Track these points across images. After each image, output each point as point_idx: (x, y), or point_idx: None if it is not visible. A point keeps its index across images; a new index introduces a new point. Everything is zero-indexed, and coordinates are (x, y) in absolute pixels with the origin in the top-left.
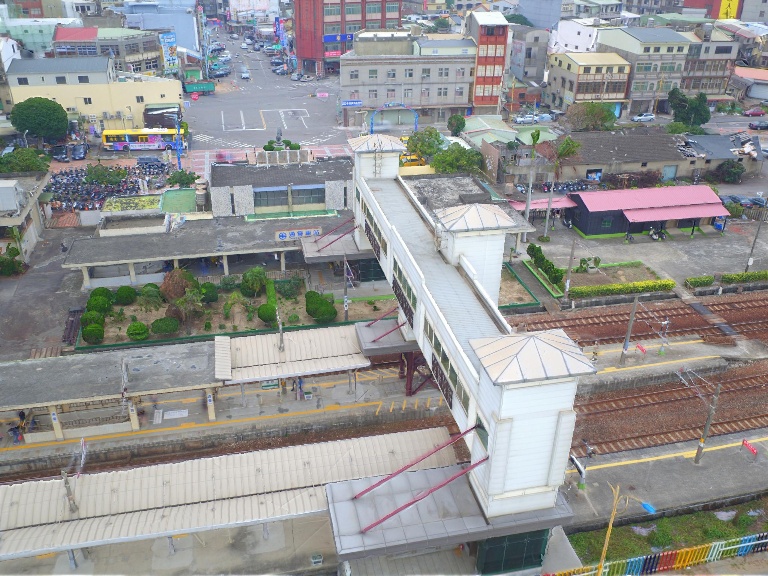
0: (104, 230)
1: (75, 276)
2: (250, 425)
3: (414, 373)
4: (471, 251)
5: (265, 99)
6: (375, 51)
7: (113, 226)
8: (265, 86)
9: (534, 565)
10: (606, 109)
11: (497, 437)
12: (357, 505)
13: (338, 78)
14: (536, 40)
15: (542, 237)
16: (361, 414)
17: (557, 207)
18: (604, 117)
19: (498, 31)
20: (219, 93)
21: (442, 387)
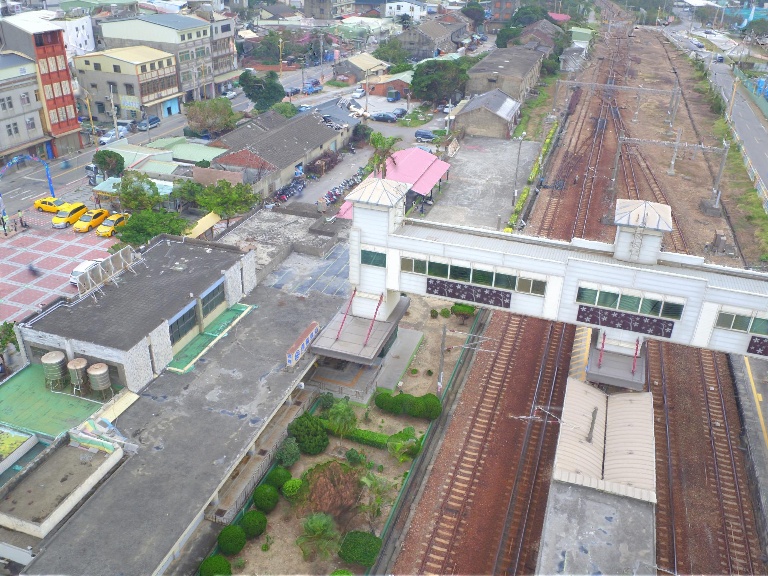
0: (46, 520)
1: None
2: None
3: None
4: None
5: None
6: None
7: (17, 510)
8: None
9: None
10: (226, 104)
11: None
12: None
13: None
14: None
15: None
16: None
17: None
18: (230, 113)
19: (46, 39)
20: None
21: None
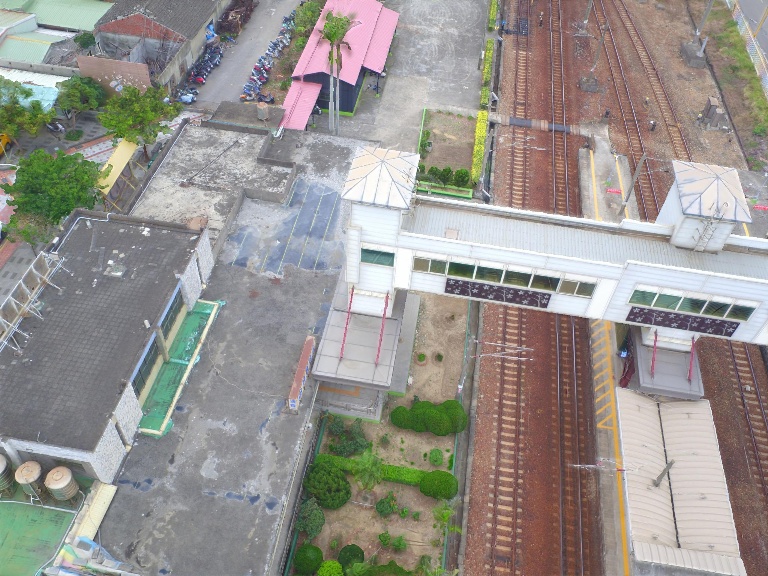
0: None
1: None
2: None
3: None
4: None
5: None
6: None
7: None
8: None
9: None
10: None
11: None
12: None
13: None
14: None
15: None
16: None
17: (315, 100)
18: None
19: None
20: None
21: None
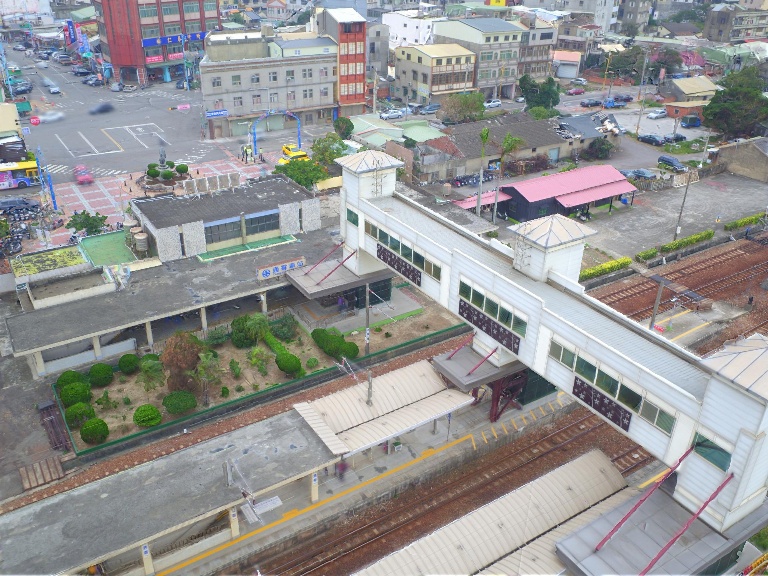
0: (39, 300)
1: (14, 363)
2: (359, 495)
3: (499, 398)
4: (557, 264)
5: (98, 116)
6: (229, 55)
7: (42, 293)
8: (86, 100)
9: (732, 563)
10: (477, 99)
11: (753, 453)
12: (603, 557)
13: (199, 87)
14: (378, 35)
15: (491, 233)
16: (461, 453)
17: None
18: (477, 107)
19: (355, 28)
20: (36, 113)
21: (603, 410)
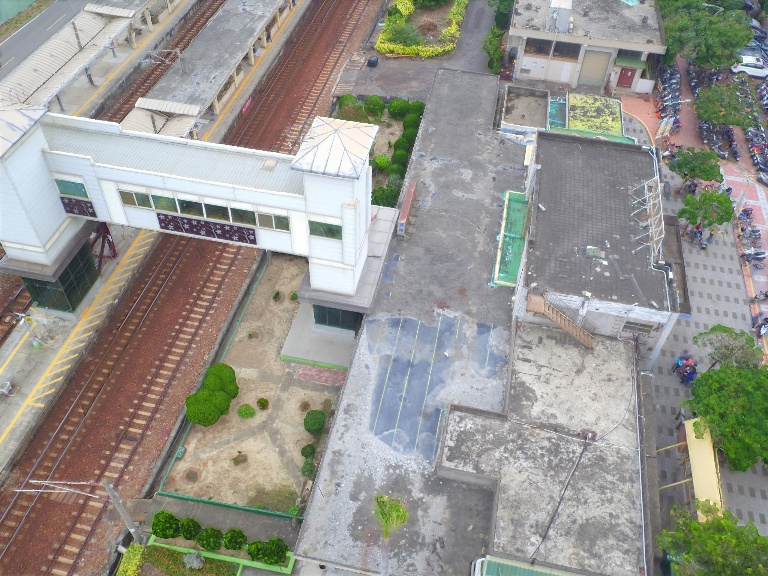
0: None
1: None
2: None
3: None
4: None
5: None
6: None
7: (533, 100)
8: None
9: None
10: None
11: None
12: None
13: None
14: None
15: None
16: None
17: None
18: None
19: None
20: None
21: None
